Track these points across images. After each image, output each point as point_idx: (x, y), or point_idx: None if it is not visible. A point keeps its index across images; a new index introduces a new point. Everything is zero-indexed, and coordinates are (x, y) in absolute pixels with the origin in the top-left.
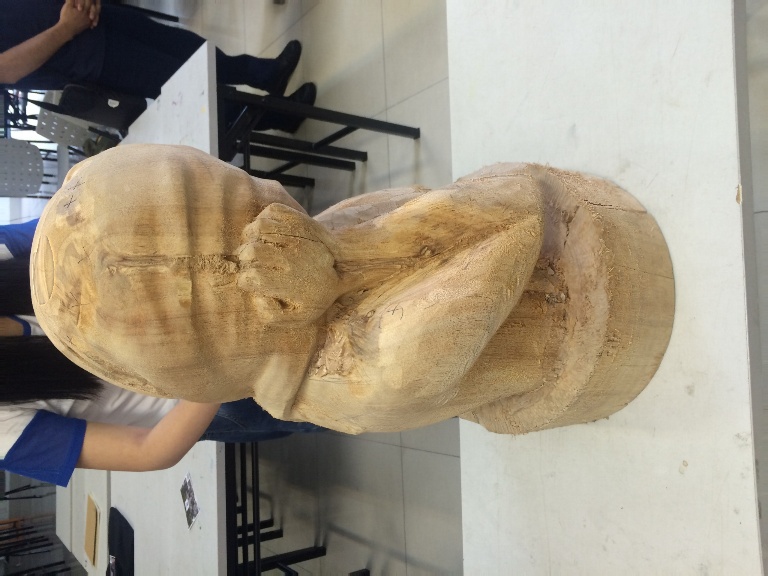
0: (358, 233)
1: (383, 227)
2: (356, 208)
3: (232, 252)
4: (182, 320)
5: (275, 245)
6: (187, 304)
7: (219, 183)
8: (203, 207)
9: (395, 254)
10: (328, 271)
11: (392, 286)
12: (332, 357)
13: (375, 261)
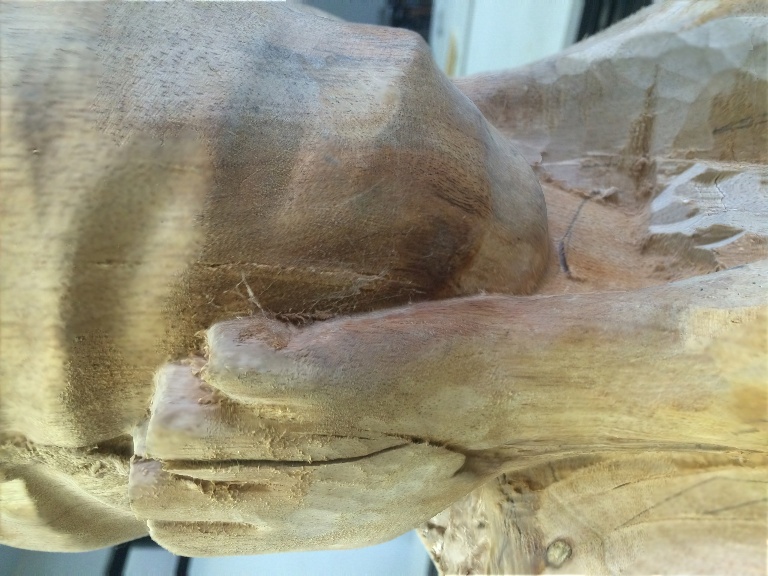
0: (600, 355)
1: (707, 354)
2: (755, 27)
3: (122, 429)
4: (30, 526)
5: (213, 486)
6: (27, 511)
7: (60, 230)
8: (3, 320)
9: (712, 440)
10: (430, 491)
11: (674, 473)
12: (459, 534)
13: (629, 441)
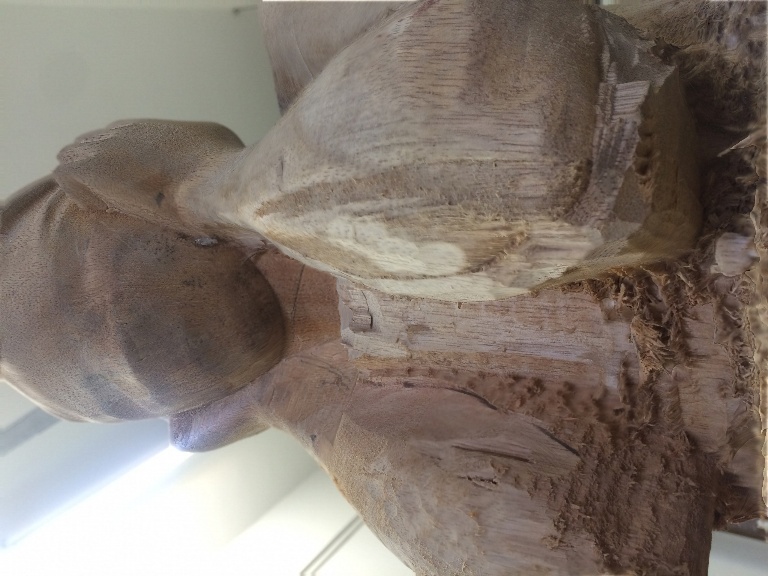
0: None
1: None
2: None
3: None
4: None
5: None
6: None
7: None
8: None
9: None
10: None
11: None
12: None
13: None
